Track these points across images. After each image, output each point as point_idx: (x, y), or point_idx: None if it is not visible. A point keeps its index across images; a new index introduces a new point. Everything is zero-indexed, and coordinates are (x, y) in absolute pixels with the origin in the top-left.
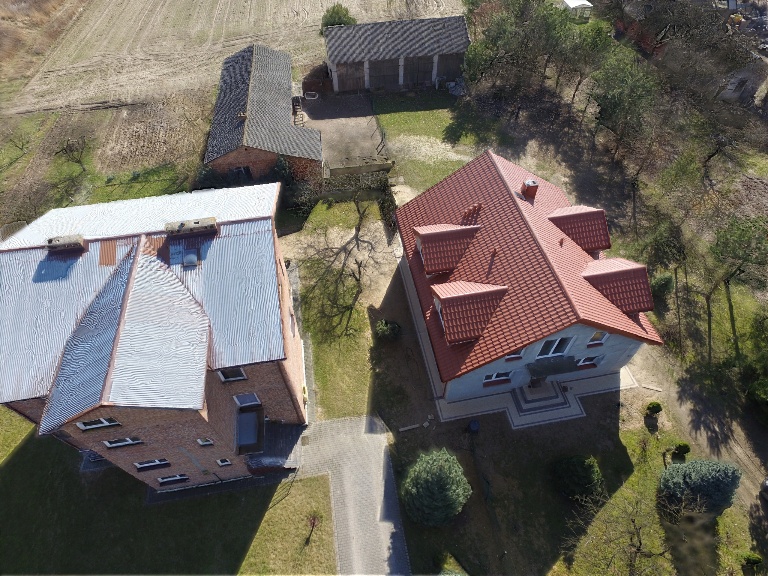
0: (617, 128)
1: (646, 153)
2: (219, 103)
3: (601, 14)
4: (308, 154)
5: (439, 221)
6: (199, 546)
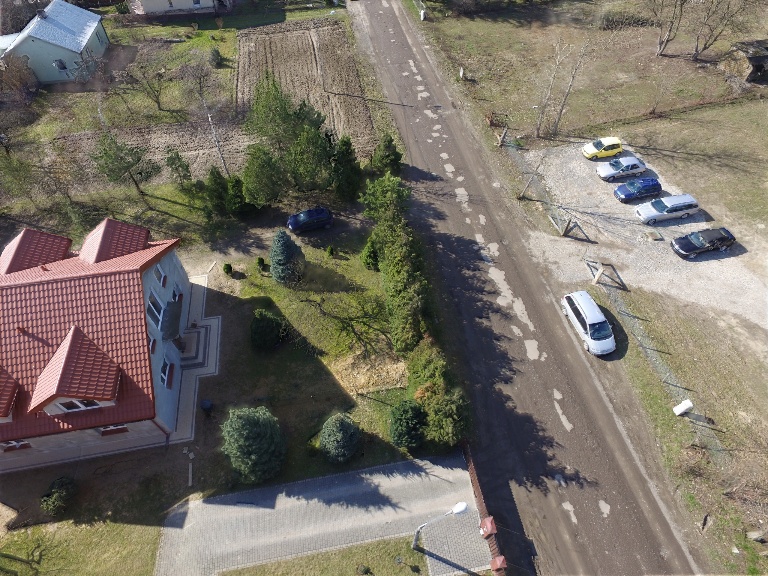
0: None
1: None
2: None
3: None
4: None
5: None
6: None
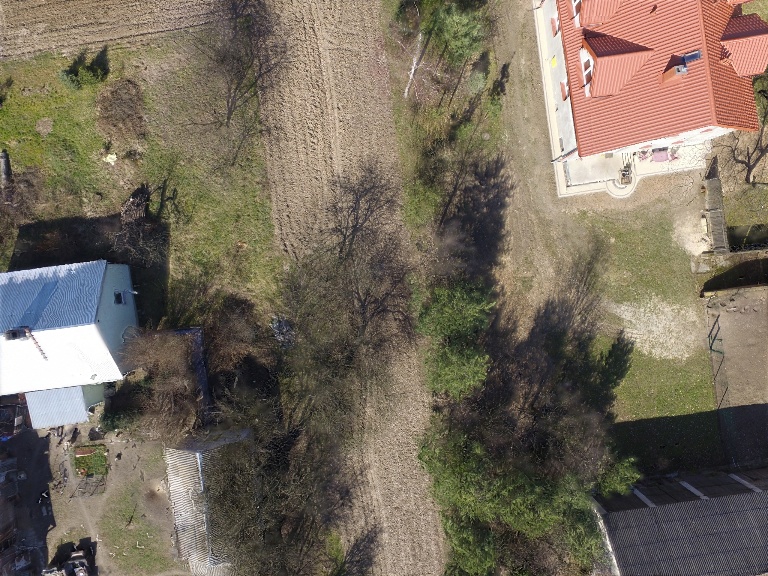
0: (465, 287)
1: None
2: None
3: None
4: None
5: None
6: None
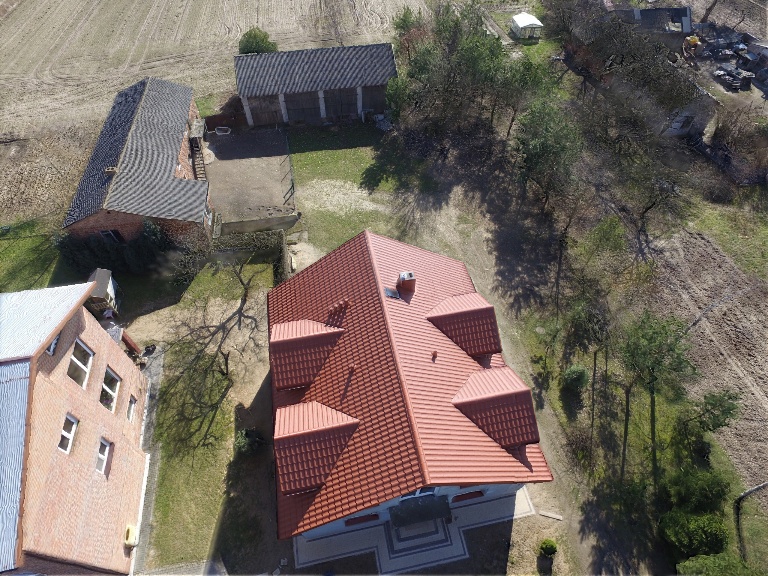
0: (542, 180)
1: (573, 209)
2: (97, 150)
3: (553, 34)
4: (187, 215)
5: (306, 315)
6: None
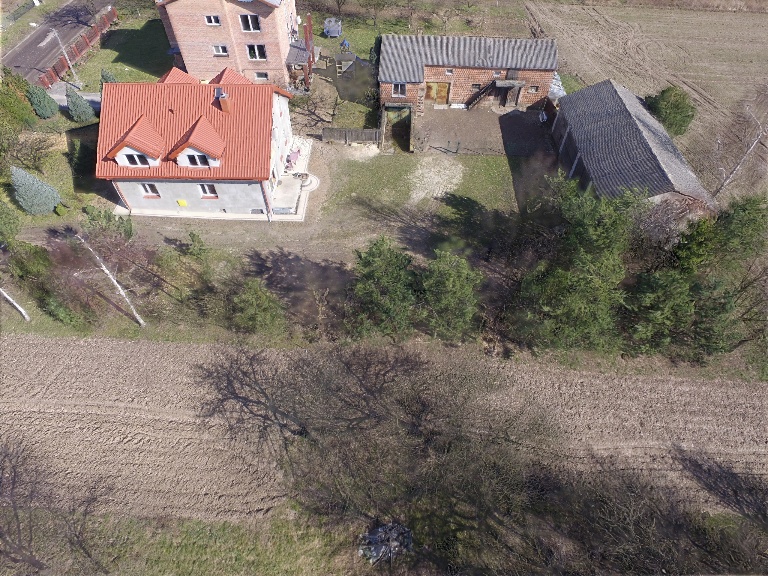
0: None
1: None
2: None
3: None
4: (385, 73)
5: None
6: (164, 65)
